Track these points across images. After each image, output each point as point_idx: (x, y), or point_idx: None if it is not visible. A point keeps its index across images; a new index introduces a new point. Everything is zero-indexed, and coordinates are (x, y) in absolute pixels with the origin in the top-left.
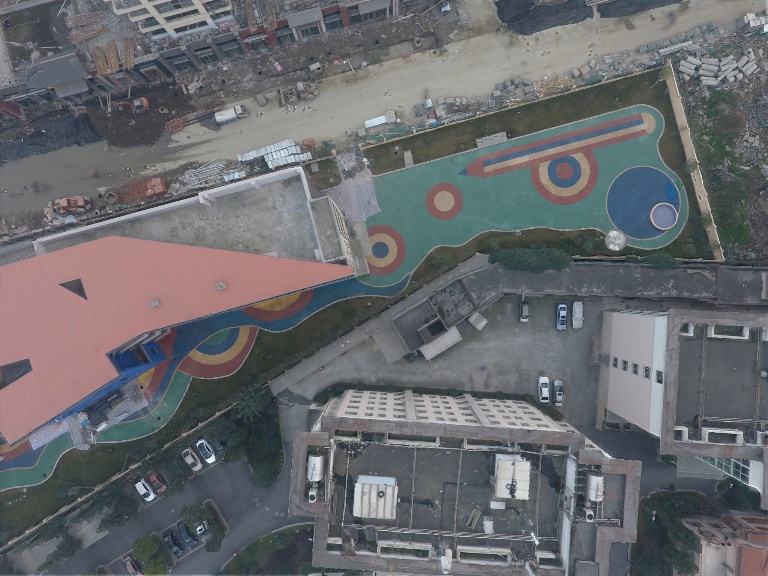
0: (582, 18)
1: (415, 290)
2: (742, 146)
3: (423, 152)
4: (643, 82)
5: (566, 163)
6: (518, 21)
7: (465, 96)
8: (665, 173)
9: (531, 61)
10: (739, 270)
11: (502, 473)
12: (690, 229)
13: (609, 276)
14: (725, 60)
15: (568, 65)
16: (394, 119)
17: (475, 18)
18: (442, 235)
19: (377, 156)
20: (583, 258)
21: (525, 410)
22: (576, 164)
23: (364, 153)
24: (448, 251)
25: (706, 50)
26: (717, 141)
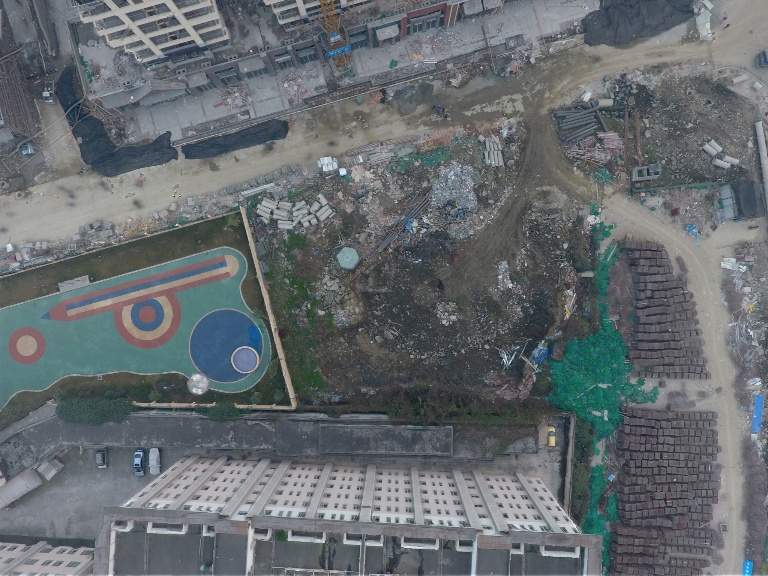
0: (166, 160)
1: None
2: (322, 289)
3: (5, 296)
4: (224, 225)
5: (149, 306)
6: (102, 163)
7: (49, 239)
8: (248, 316)
9: (115, 203)
10: (299, 421)
11: None
12: None
13: (169, 428)
14: (297, 205)
15: (152, 207)
16: None
17: (59, 160)
18: (25, 380)
19: None
20: (153, 406)
21: (63, 571)
22: (159, 307)
23: None
24: (29, 396)
25: (287, 192)
26: (299, 284)
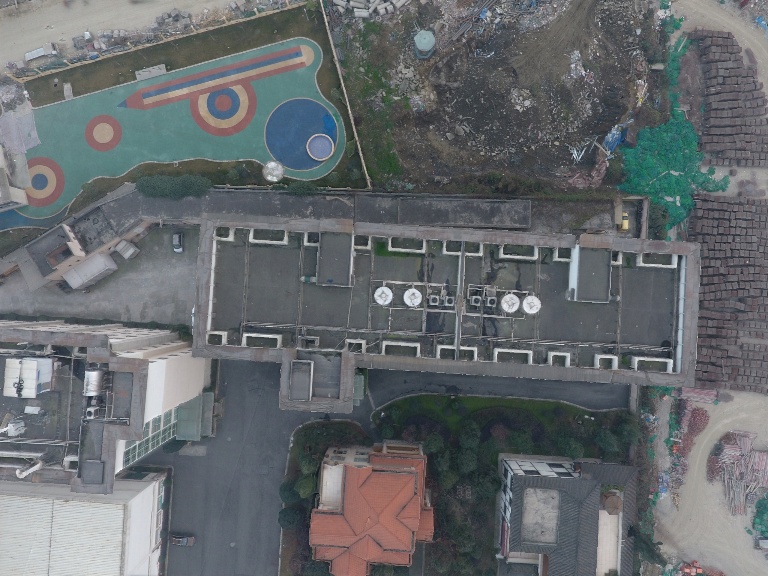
0: None
1: (64, 219)
2: (397, 77)
3: (82, 84)
4: (300, 15)
5: (225, 95)
6: None
7: (126, 29)
8: (323, 105)
9: None
10: (378, 197)
11: (9, 372)
12: (346, 160)
13: (248, 203)
14: None
15: None
16: (50, 51)
17: None
18: (101, 167)
19: (37, 88)
20: (231, 187)
21: (146, 333)
22: (235, 96)
23: (25, 86)
24: (105, 182)
25: None
26: (374, 73)
